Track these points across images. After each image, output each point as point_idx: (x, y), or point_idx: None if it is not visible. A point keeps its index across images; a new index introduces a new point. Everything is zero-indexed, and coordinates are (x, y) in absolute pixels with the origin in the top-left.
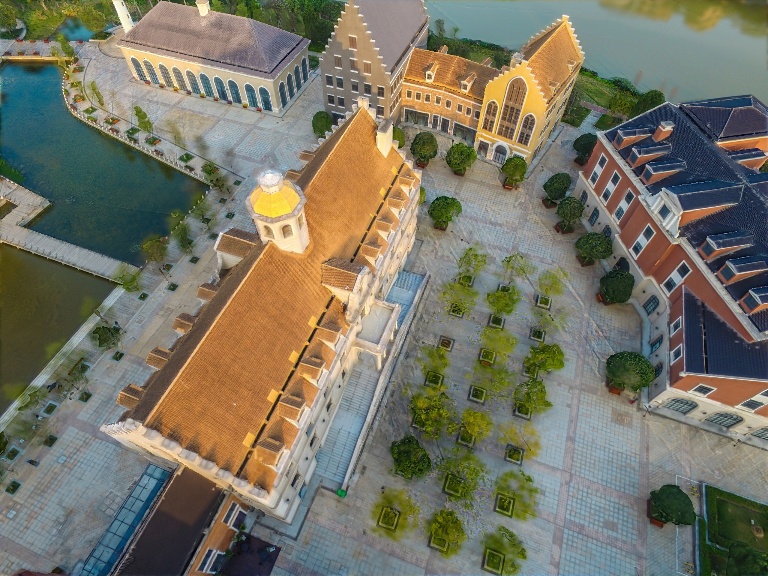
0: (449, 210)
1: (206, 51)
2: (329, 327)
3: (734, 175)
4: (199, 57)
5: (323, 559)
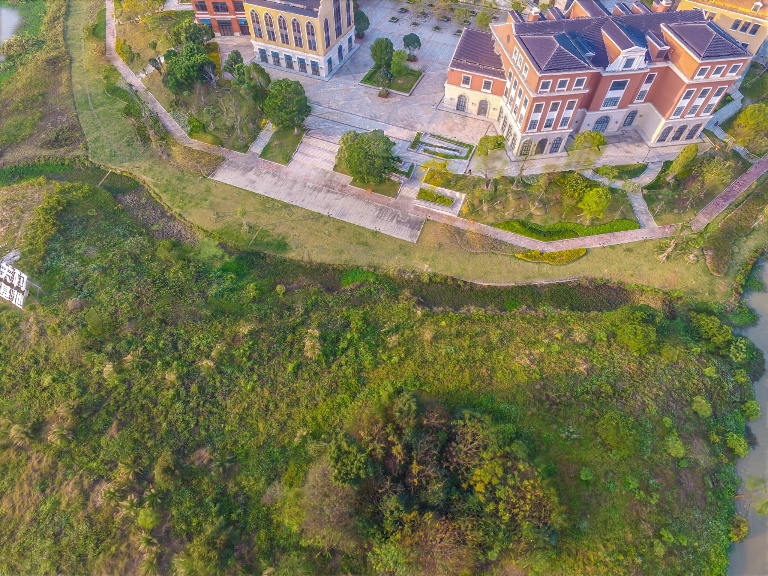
0: None
1: None
2: None
3: None
4: None
5: None
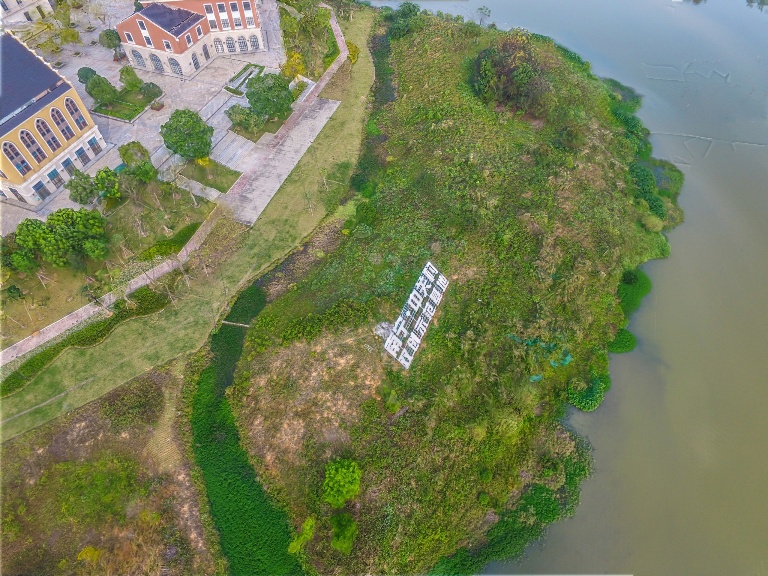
0: None
1: None
2: None
3: None
4: None
5: None
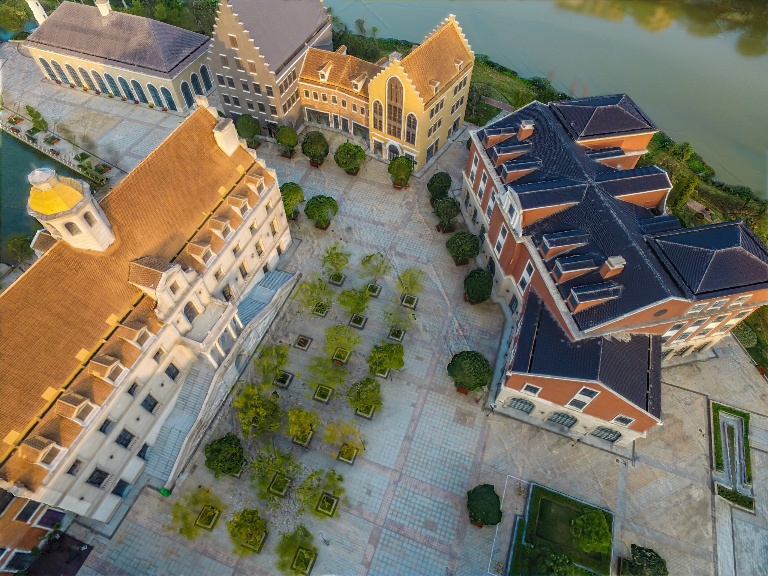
0: (321, 209)
1: (107, 51)
2: (131, 325)
3: (581, 174)
4: (101, 57)
5: (133, 558)
